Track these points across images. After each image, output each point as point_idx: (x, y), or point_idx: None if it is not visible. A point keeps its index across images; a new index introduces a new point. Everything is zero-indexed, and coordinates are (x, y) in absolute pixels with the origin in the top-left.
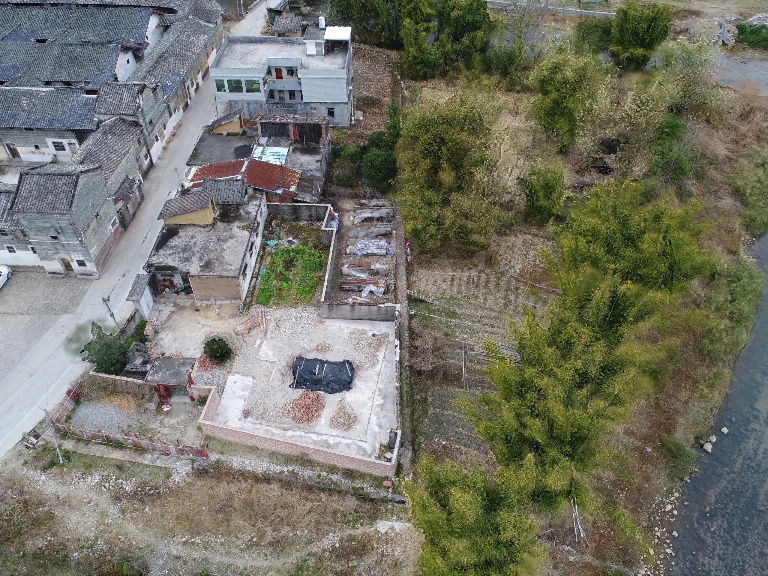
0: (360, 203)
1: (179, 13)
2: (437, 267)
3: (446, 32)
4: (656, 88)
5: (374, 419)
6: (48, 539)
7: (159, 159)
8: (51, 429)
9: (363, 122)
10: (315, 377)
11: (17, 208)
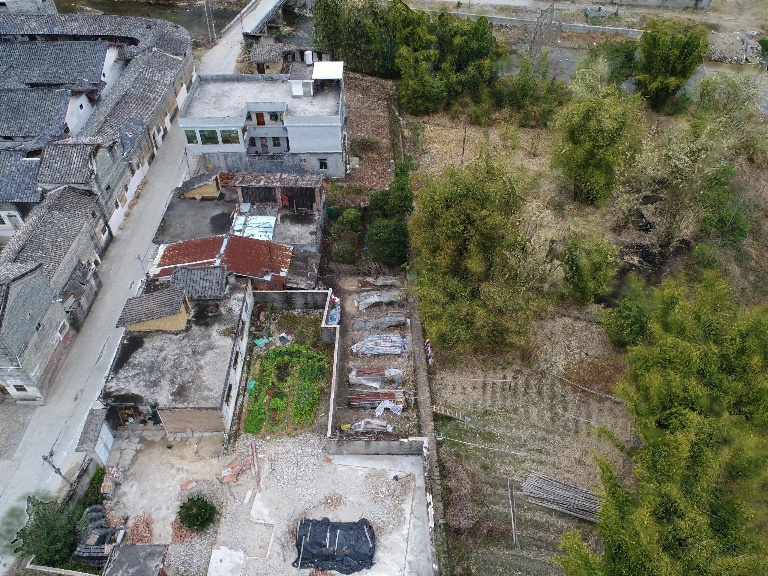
0: (364, 282)
1: (141, 44)
2: (464, 368)
3: (449, 60)
4: (709, 135)
5: None
6: None
7: (120, 229)
8: None
9: (360, 171)
10: (326, 551)
11: None
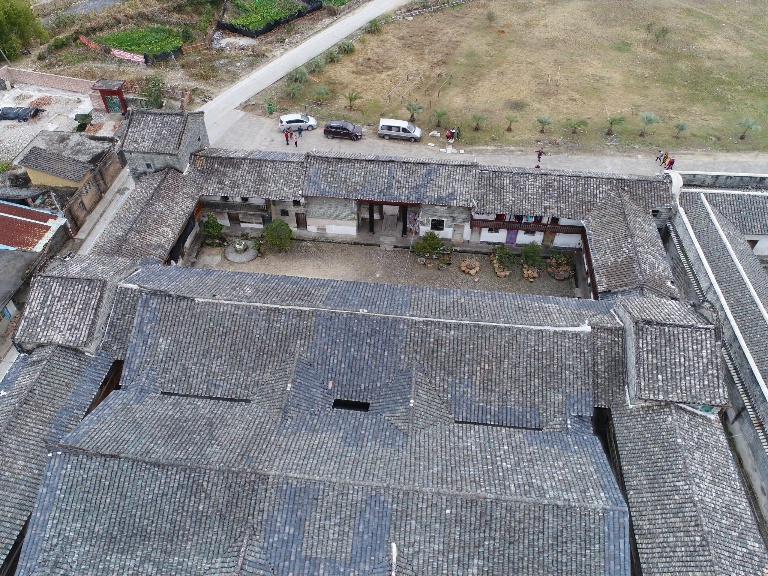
0: None
1: None
2: None
3: None
4: None
5: (5, 98)
6: None
7: None
8: None
9: None
10: None
11: None
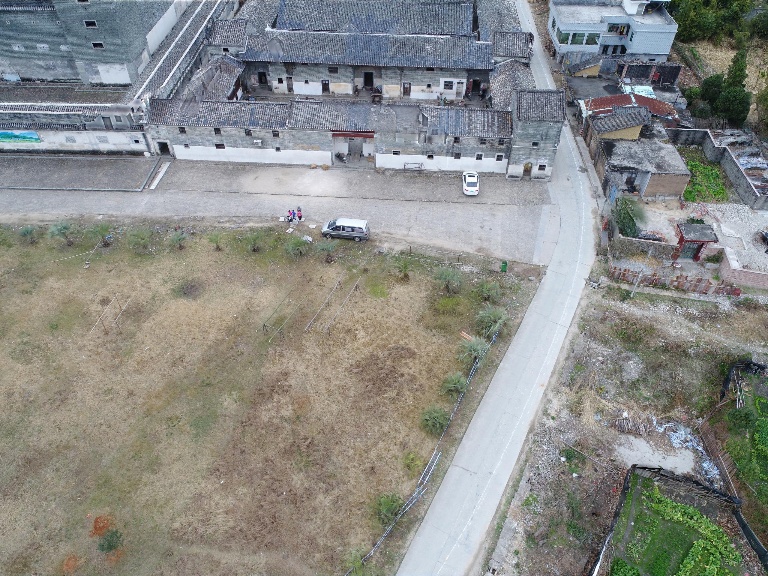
0: (717, 132)
1: None
2: None
3: (713, 0)
4: None
5: None
6: (663, 341)
7: None
8: (644, 265)
9: None
10: None
11: (524, 117)
